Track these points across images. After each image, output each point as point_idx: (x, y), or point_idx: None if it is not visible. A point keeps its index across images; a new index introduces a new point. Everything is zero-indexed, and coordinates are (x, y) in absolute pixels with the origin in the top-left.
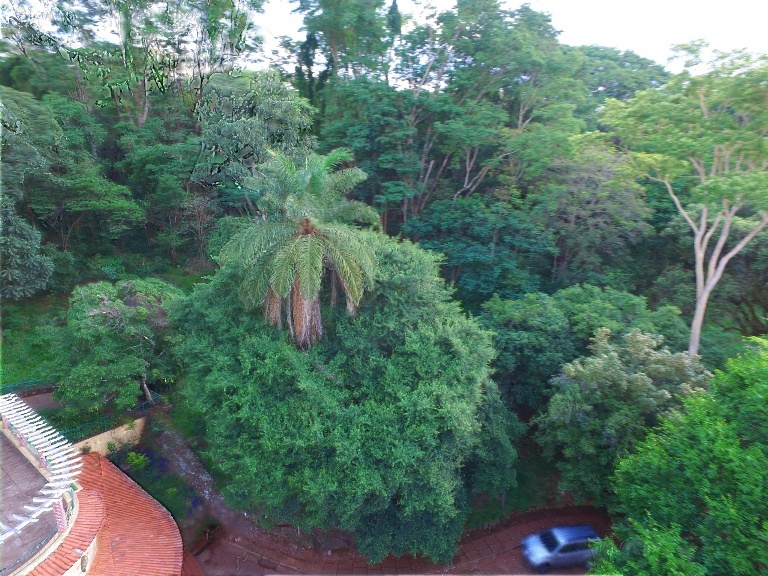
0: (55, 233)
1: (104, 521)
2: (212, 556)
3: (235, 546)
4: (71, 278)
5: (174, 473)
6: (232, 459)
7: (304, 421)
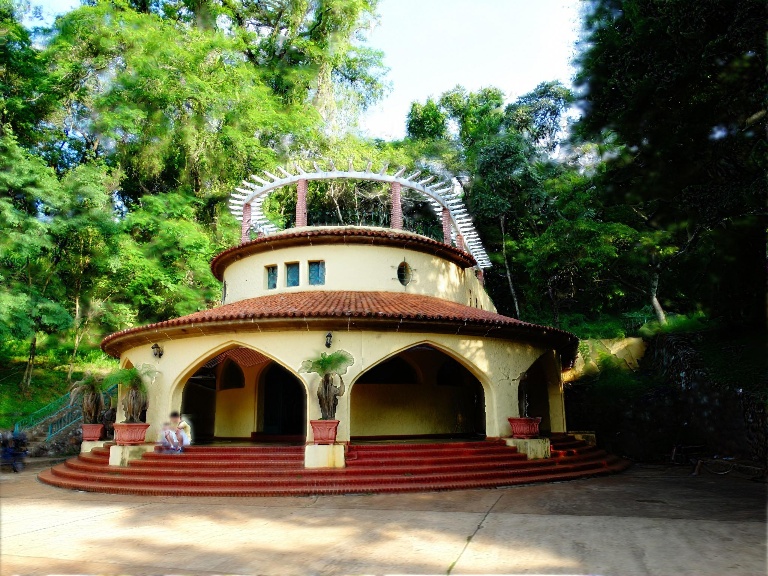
0: None
1: None
2: (662, 467)
3: None
4: (646, 286)
5: None
6: None
7: None
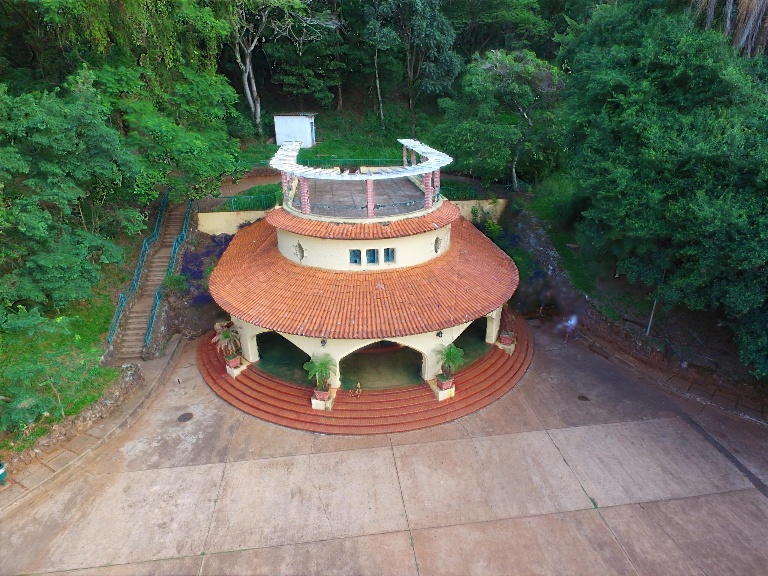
0: (466, 55)
1: (458, 239)
2: (542, 325)
3: (567, 325)
4: None
5: (523, 249)
6: (597, 175)
7: (716, 129)
